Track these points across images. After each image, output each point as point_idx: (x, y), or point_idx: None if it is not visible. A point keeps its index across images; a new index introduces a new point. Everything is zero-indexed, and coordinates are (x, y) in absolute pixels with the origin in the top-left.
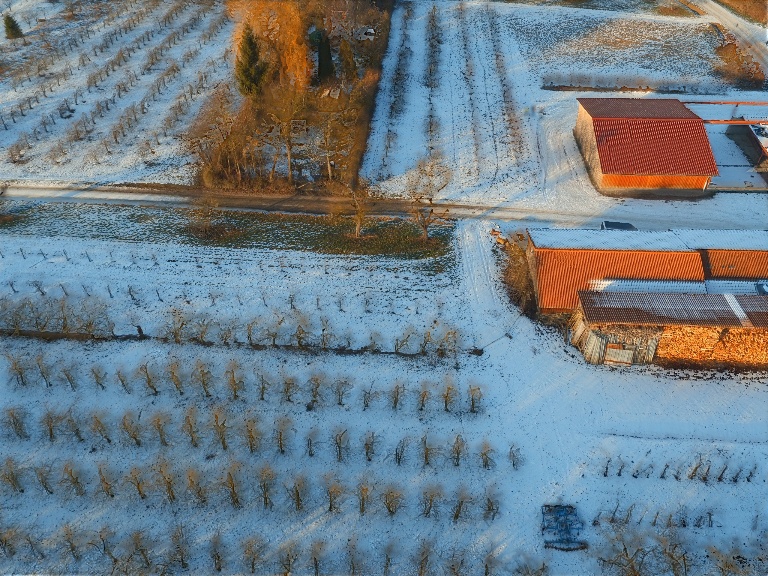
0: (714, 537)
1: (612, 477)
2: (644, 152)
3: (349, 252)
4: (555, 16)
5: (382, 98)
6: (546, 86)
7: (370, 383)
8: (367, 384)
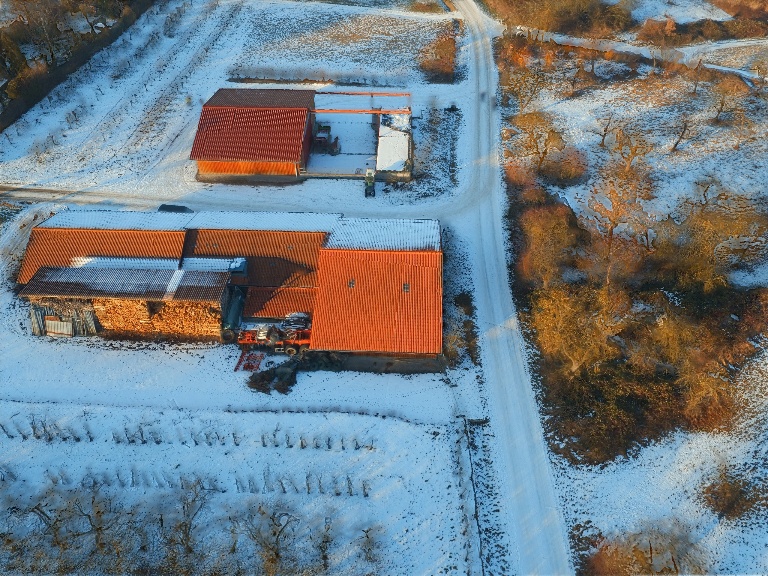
0: (6, 490)
1: None
2: (238, 139)
3: None
4: (305, 12)
5: (59, 89)
6: (232, 78)
7: None
8: None
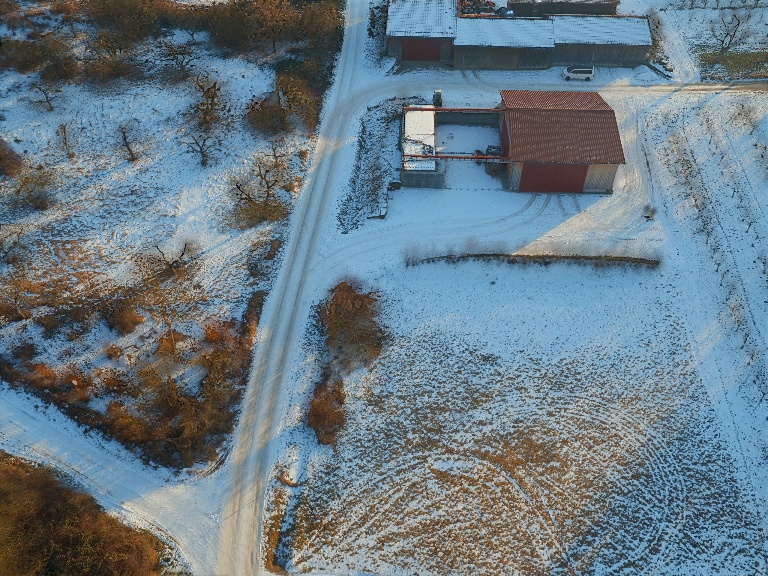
0: None
1: None
2: None
3: (765, 53)
4: None
5: None
6: (654, 265)
7: None
8: None
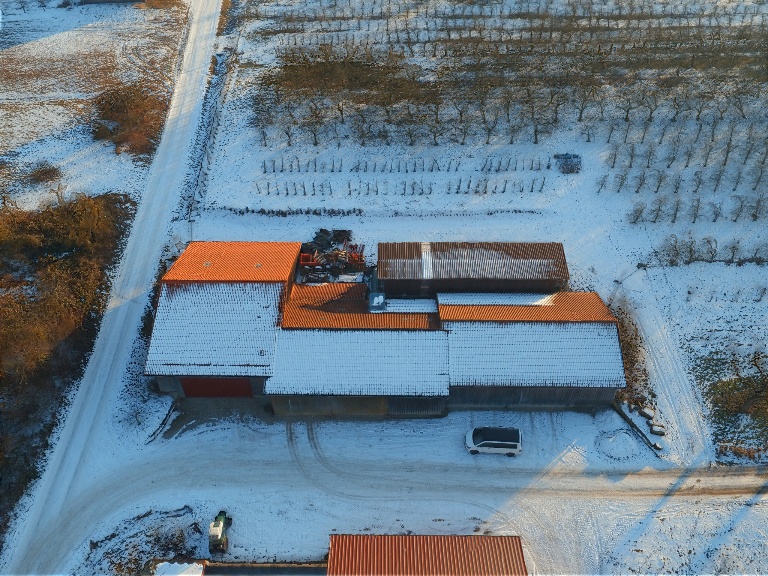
0: None
1: (536, 190)
2: None
3: None
4: None
5: None
6: None
7: (720, 237)
8: (722, 236)
